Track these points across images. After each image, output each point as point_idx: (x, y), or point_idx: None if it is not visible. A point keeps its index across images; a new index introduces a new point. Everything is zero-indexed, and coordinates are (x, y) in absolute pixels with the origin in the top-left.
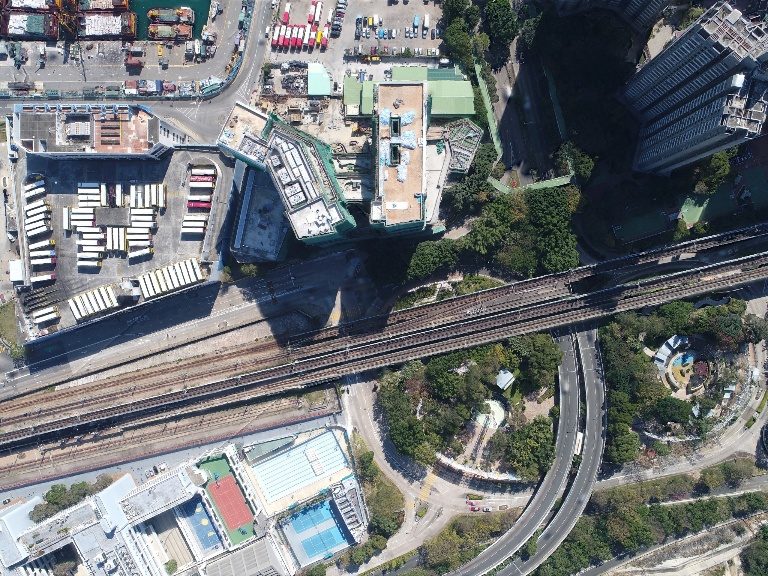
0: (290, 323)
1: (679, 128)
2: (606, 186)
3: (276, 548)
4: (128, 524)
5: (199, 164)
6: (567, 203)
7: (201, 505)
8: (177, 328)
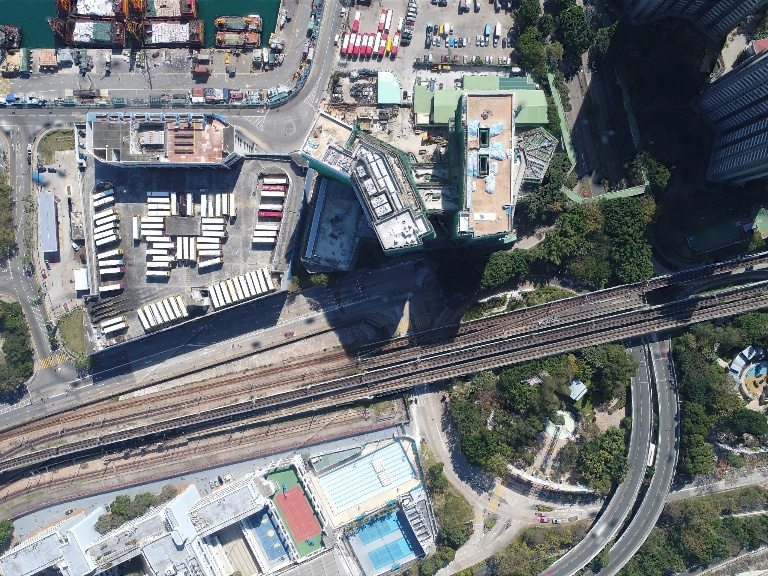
0: (358, 333)
1: (766, 139)
2: (678, 196)
3: (344, 560)
4: (197, 536)
5: (270, 173)
6: (642, 213)
7: (267, 516)
8: (243, 338)
